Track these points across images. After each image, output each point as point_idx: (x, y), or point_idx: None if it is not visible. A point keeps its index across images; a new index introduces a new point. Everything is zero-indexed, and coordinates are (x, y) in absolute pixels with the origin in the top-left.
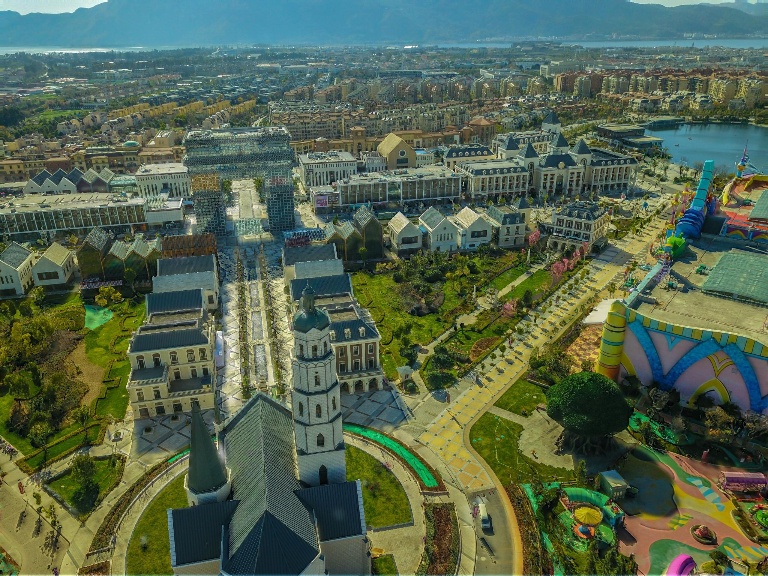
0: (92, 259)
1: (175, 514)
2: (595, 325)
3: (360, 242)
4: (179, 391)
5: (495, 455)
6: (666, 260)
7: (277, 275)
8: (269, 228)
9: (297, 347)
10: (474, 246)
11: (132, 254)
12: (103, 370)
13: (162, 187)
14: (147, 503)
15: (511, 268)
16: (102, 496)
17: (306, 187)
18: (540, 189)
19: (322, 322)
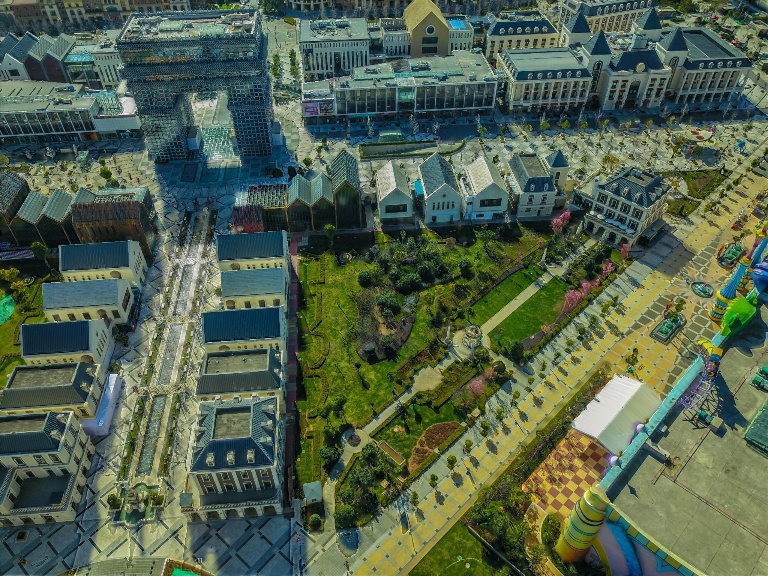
0: None
1: None
2: (586, 436)
3: (330, 209)
4: (23, 508)
5: None
6: (707, 375)
7: None
8: (239, 151)
9: None
10: (483, 216)
11: (43, 218)
12: None
13: None
14: None
15: (518, 271)
16: None
17: (304, 72)
18: (604, 99)
19: None
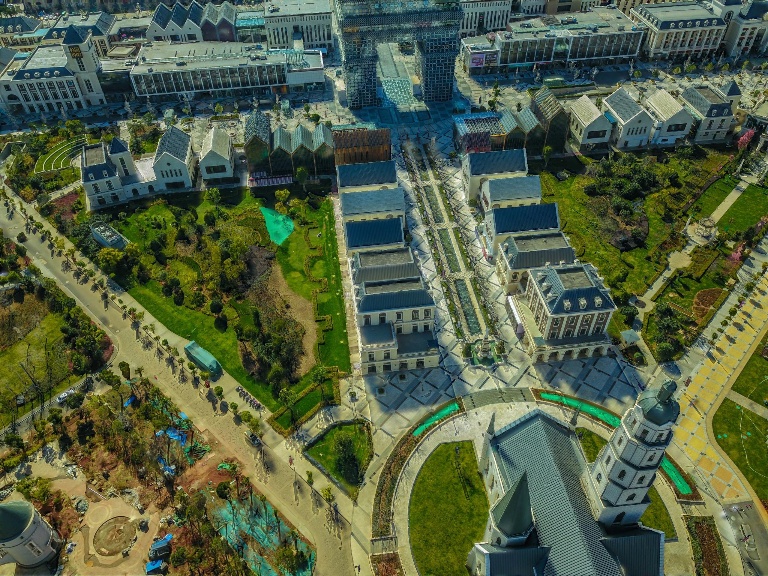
0: (260, 153)
1: (491, 557)
2: None
3: (542, 136)
4: (407, 353)
5: (745, 459)
6: None
7: (450, 174)
8: (423, 97)
9: (639, 430)
10: (667, 141)
11: (300, 148)
12: (310, 304)
13: (292, 31)
14: (410, 487)
15: (717, 180)
16: (363, 471)
17: None
18: (733, 46)
19: (677, 413)
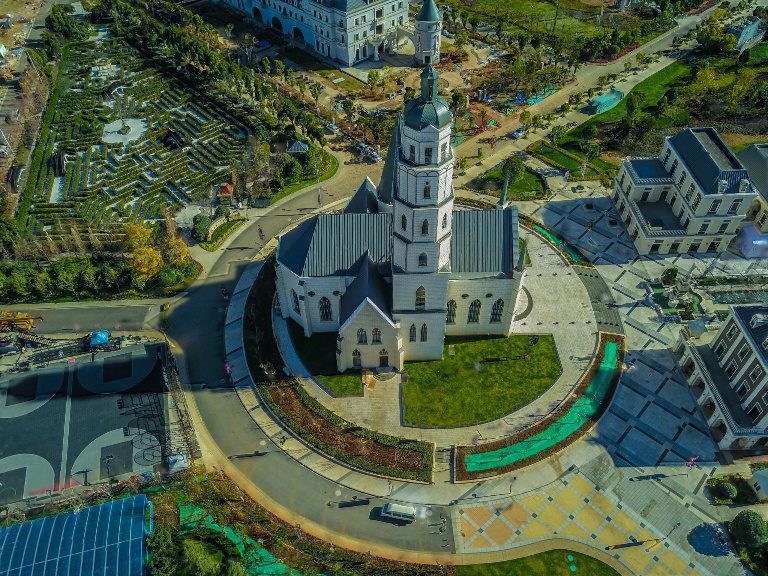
0: None
1: None
2: None
3: None
4: None
5: None
6: None
7: None
8: None
9: None
10: None
11: None
12: None
13: None
14: None
15: None
16: (490, 192)
17: None
18: None
19: (413, 119)
